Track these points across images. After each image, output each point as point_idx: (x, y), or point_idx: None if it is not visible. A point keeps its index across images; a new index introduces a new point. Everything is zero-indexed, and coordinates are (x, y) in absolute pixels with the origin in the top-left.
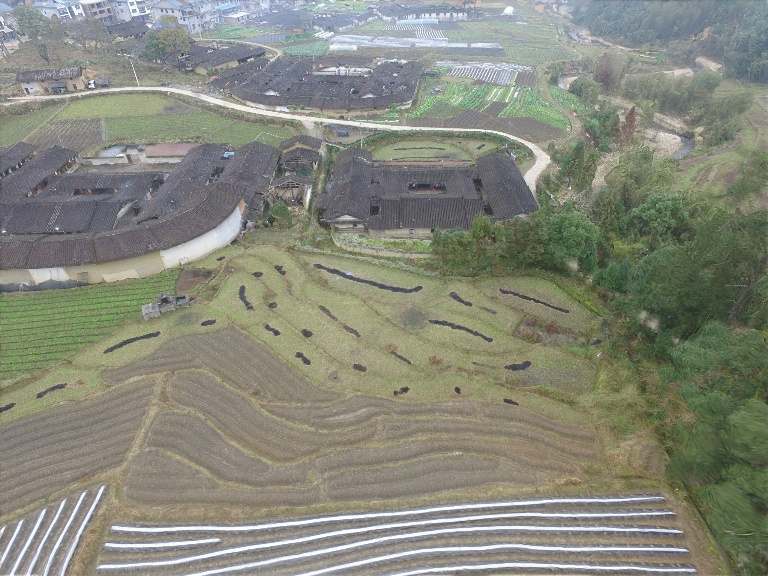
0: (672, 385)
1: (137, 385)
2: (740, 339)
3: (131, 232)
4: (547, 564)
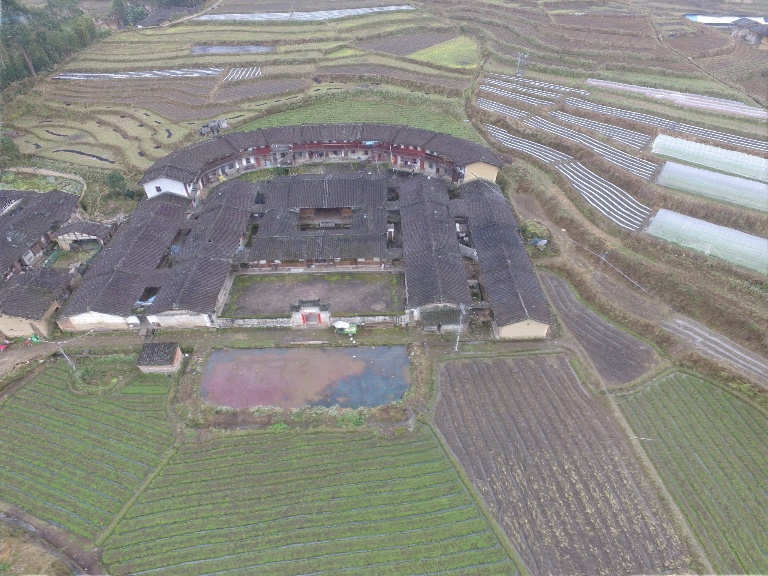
0: None
1: (221, 100)
2: (0, 26)
3: (235, 134)
4: (100, 73)
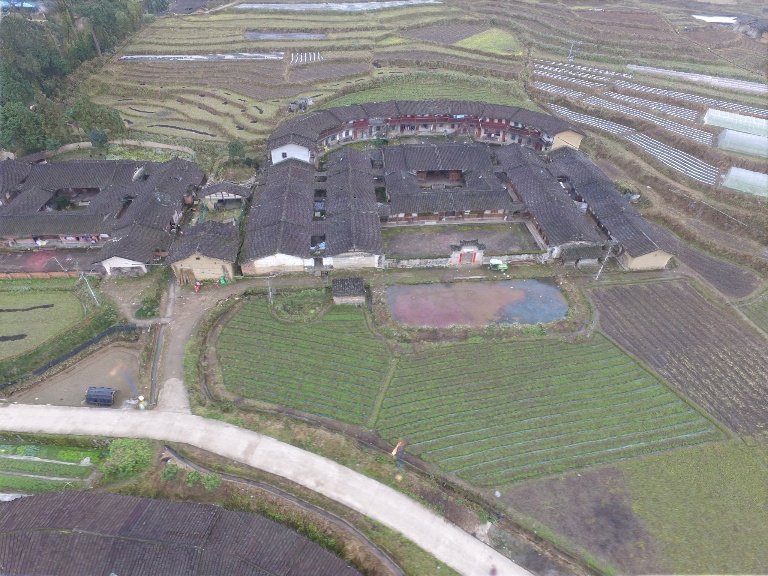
0: (74, 74)
1: (296, 80)
2: None
3: None
4: (164, 55)
